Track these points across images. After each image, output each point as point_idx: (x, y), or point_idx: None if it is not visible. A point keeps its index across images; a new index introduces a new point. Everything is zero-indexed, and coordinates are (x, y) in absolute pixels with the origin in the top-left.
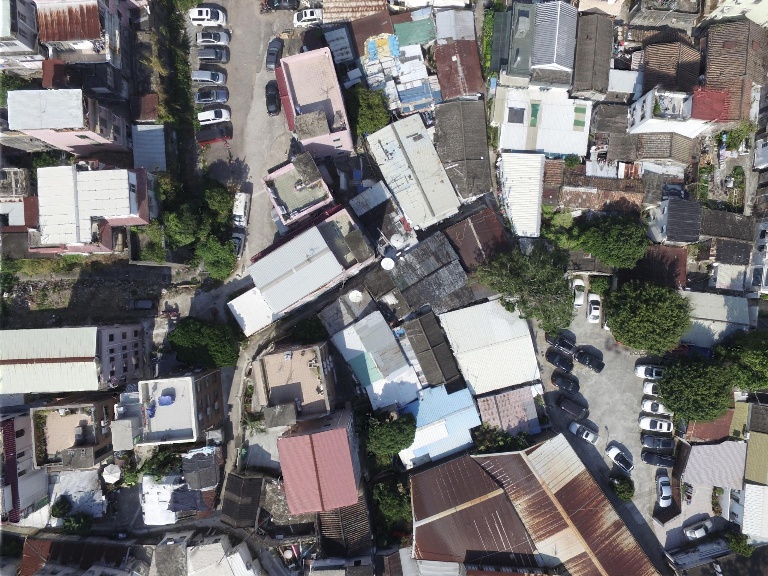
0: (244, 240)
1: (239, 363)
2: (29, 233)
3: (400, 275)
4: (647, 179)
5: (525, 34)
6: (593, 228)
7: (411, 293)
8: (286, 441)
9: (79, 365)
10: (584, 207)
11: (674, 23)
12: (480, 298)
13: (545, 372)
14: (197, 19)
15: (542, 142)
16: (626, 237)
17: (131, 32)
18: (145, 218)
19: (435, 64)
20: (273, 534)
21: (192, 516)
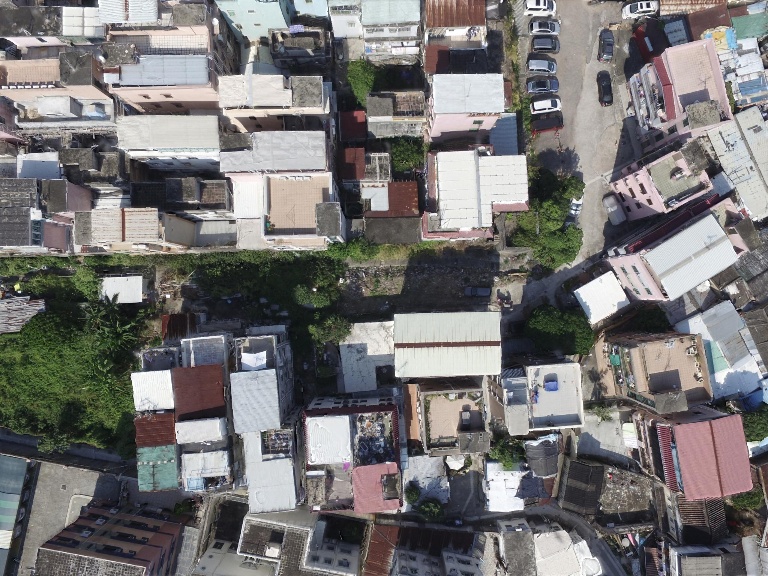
0: None
1: None
2: (426, 217)
3: (743, 265)
4: None
5: None
6: None
7: (756, 283)
8: (685, 427)
9: (485, 349)
10: None
11: None
12: None
13: None
14: (534, 9)
15: None
16: None
17: None
18: (527, 204)
19: None
20: (602, 522)
21: (535, 503)
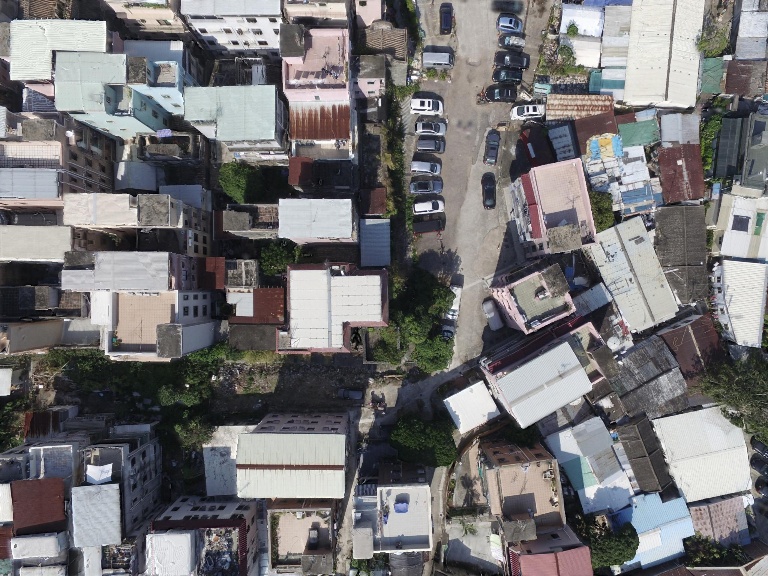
0: None
1: None
2: (277, 335)
3: (618, 379)
4: None
5: (763, 146)
6: None
7: (630, 399)
8: (530, 558)
9: (328, 473)
10: None
11: None
12: (694, 405)
13: None
14: (418, 109)
15: (764, 251)
16: None
17: (360, 123)
18: (386, 321)
19: (659, 167)
20: None
21: None
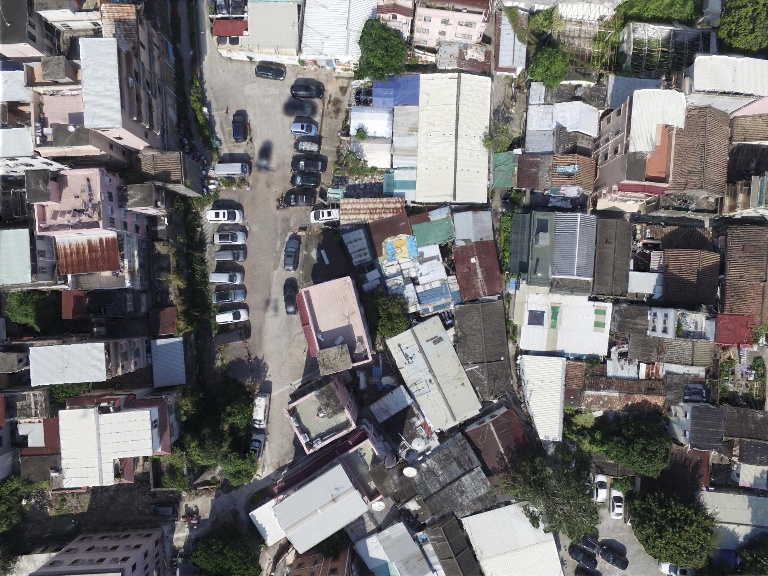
0: (264, 440)
1: (260, 563)
2: None
3: (422, 482)
4: (669, 381)
5: (545, 245)
6: (616, 437)
7: (434, 501)
8: None
9: None
10: (606, 408)
11: (692, 216)
12: (503, 501)
13: (568, 567)
14: (214, 220)
15: (562, 343)
16: (650, 454)
17: (149, 242)
18: (167, 449)
19: (454, 265)
20: None
21: None
